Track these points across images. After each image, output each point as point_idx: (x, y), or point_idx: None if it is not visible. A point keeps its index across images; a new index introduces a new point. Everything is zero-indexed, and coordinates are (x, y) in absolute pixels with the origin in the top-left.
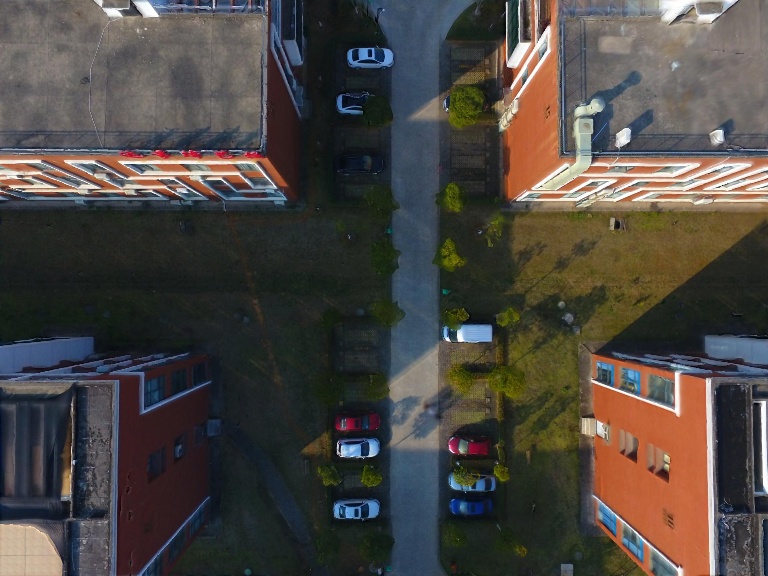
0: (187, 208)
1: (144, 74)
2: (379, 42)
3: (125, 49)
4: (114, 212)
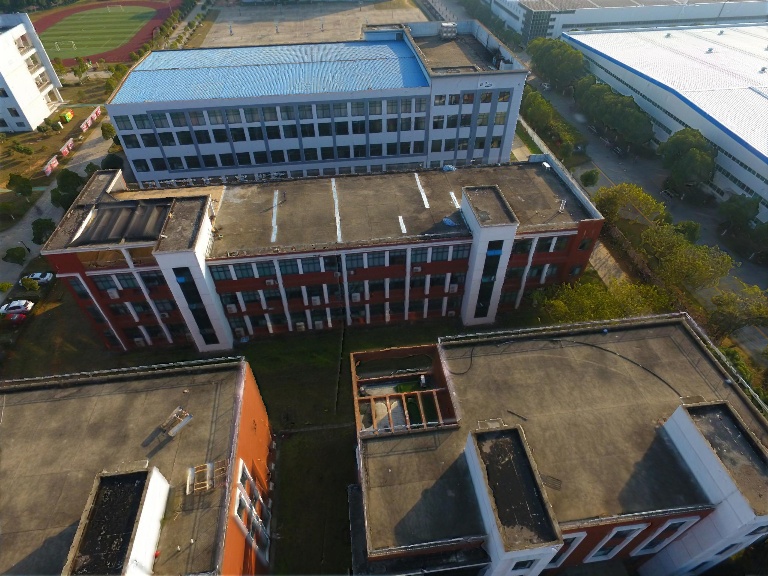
0: None
1: None
2: None
3: None
4: None
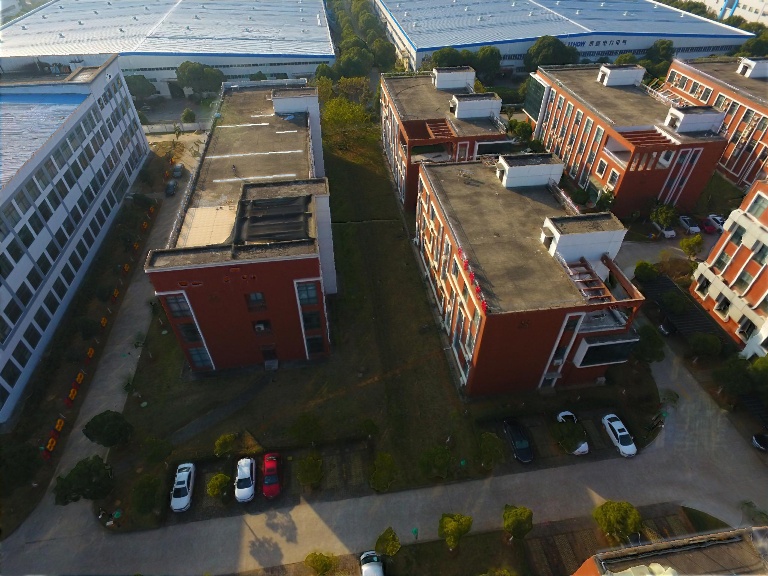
0: (439, 327)
1: (513, 255)
2: (637, 439)
3: (524, 247)
4: (424, 291)
